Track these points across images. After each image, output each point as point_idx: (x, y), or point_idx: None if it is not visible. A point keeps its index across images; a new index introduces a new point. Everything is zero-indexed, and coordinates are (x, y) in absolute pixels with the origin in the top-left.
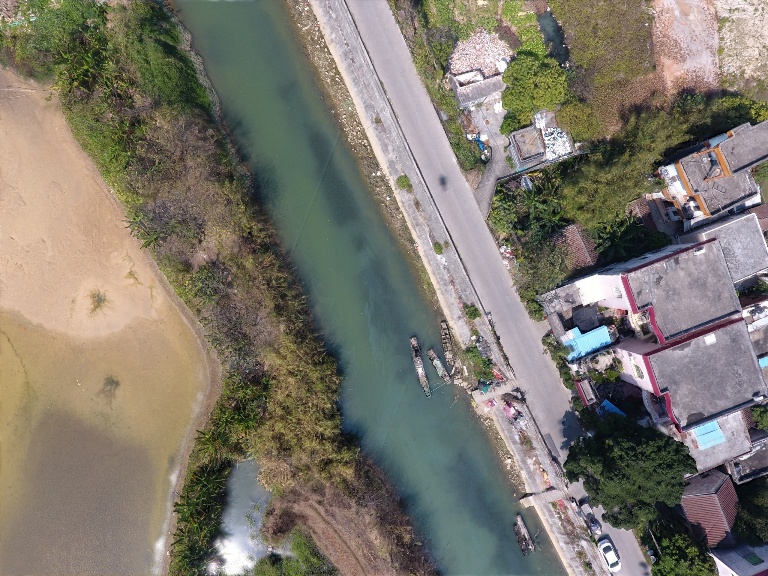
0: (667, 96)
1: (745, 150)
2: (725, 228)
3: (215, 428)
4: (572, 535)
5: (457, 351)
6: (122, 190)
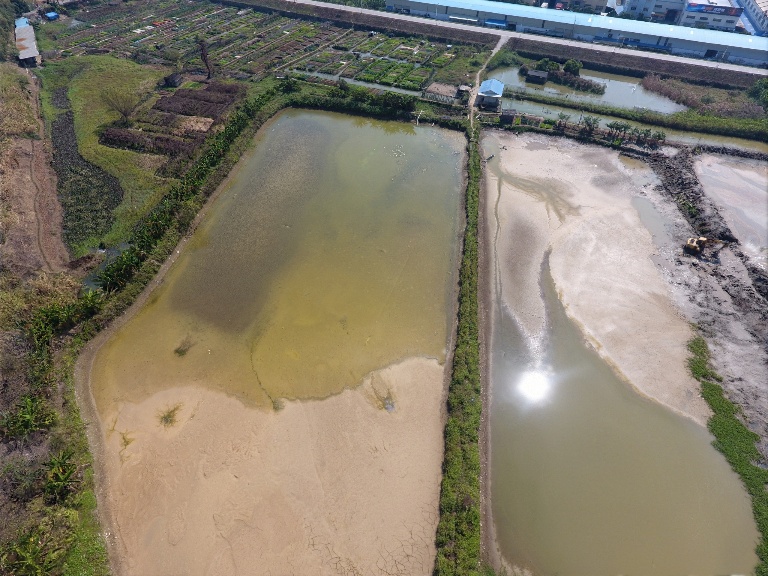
0: None
1: None
2: None
3: (79, 308)
4: None
5: None
6: None
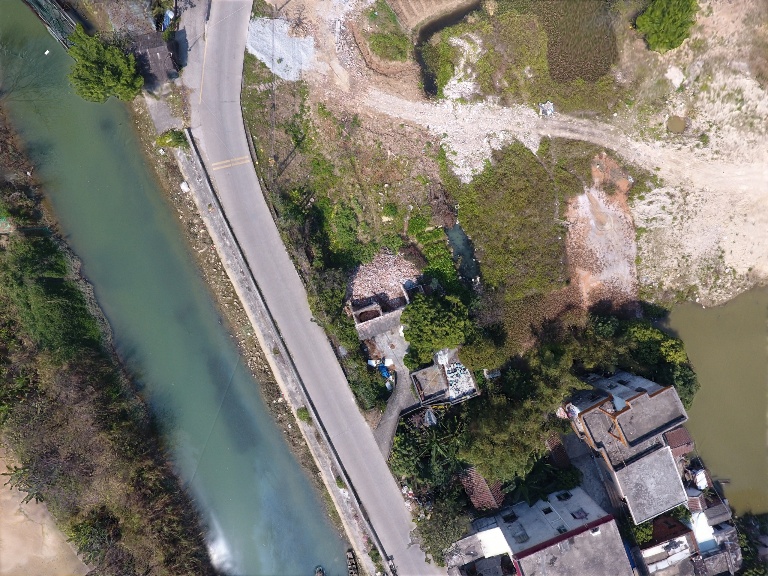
0: (583, 308)
1: (644, 419)
2: (637, 463)
3: None
4: None
5: None
6: (2, 442)
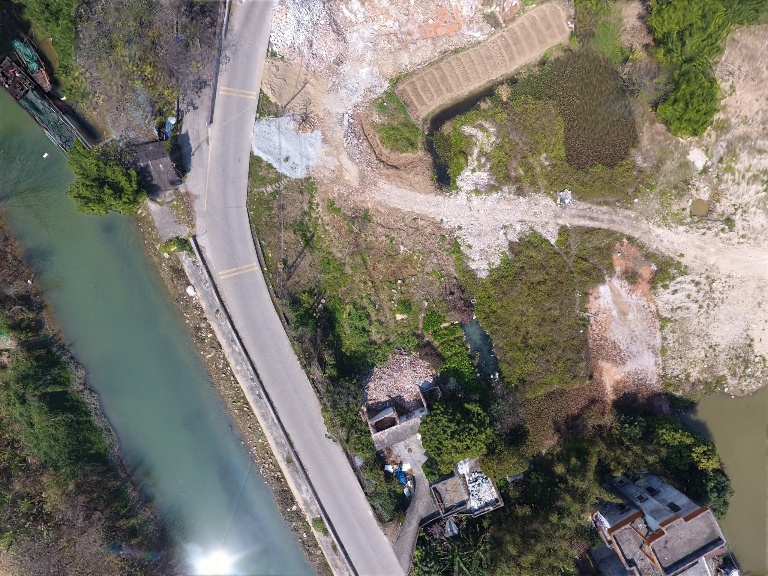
0: (607, 402)
1: (679, 543)
2: None
3: None
4: None
5: None
6: None
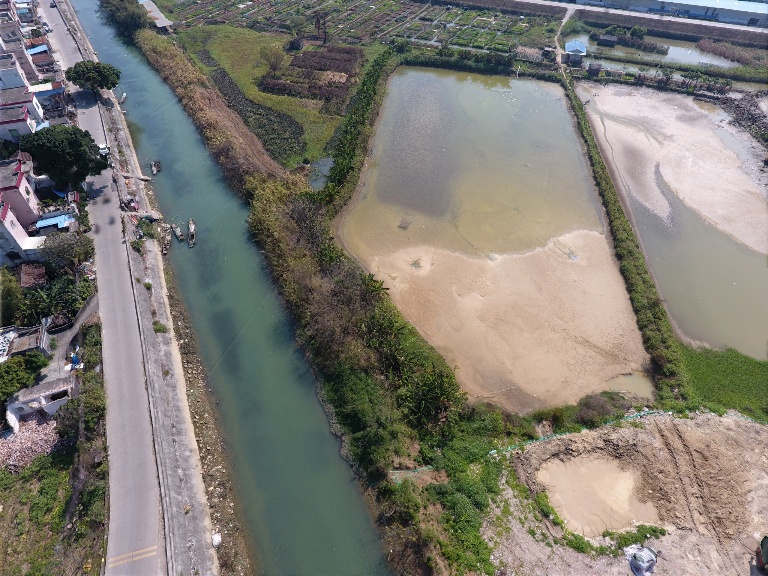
0: None
1: None
2: None
3: None
4: (124, 162)
5: (161, 240)
6: None
